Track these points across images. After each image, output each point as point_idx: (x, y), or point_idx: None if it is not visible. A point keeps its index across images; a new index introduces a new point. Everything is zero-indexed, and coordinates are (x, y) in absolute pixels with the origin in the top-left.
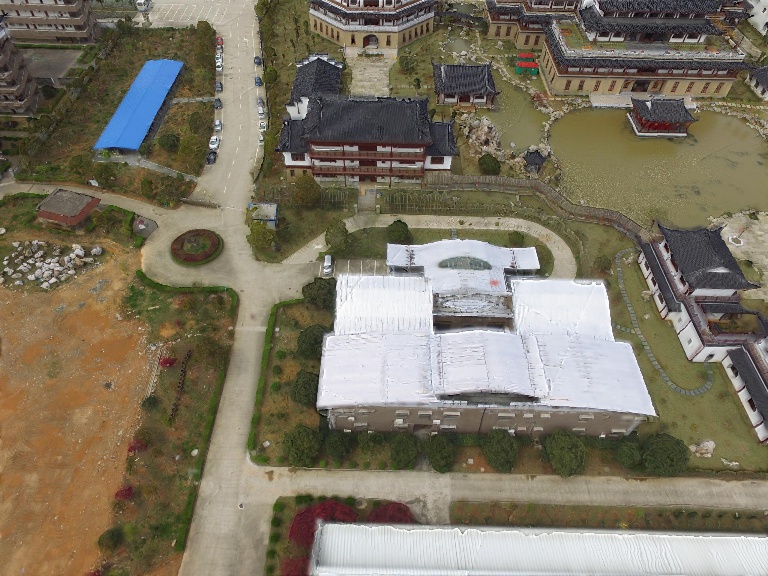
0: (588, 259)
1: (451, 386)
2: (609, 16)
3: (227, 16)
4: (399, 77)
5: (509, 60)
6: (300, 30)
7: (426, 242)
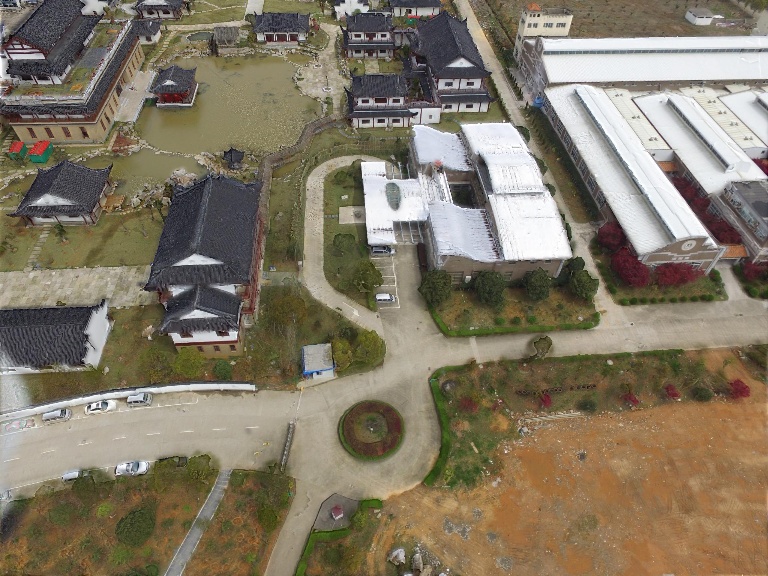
0: (371, 140)
1: (536, 184)
2: (45, 55)
3: None
4: (6, 260)
5: (19, 161)
6: None
7: None
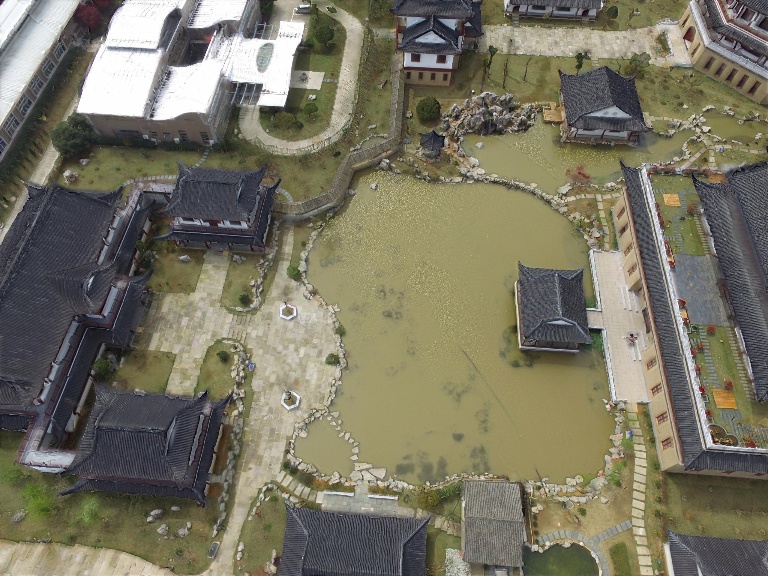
0: None
1: (130, 5)
2: None
3: None
4: None
5: None
6: None
7: (323, 63)
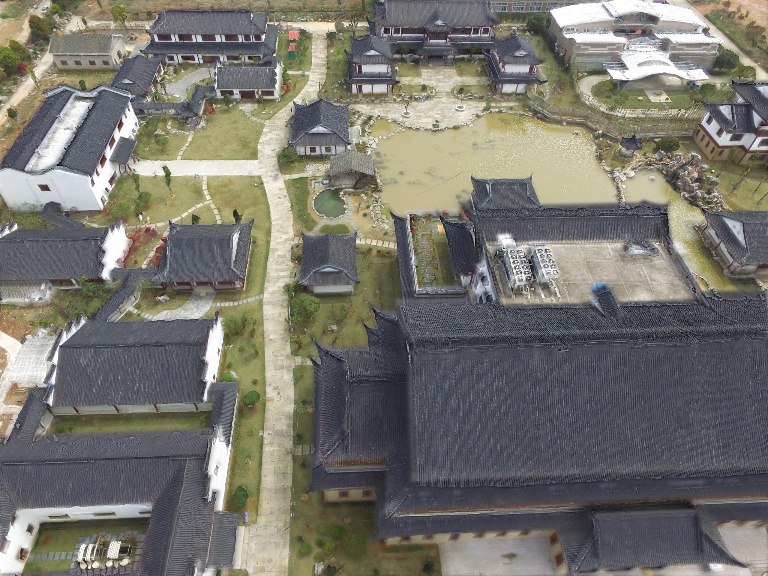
0: None
1: (645, 3)
2: None
3: None
4: None
5: None
6: None
7: (683, 101)
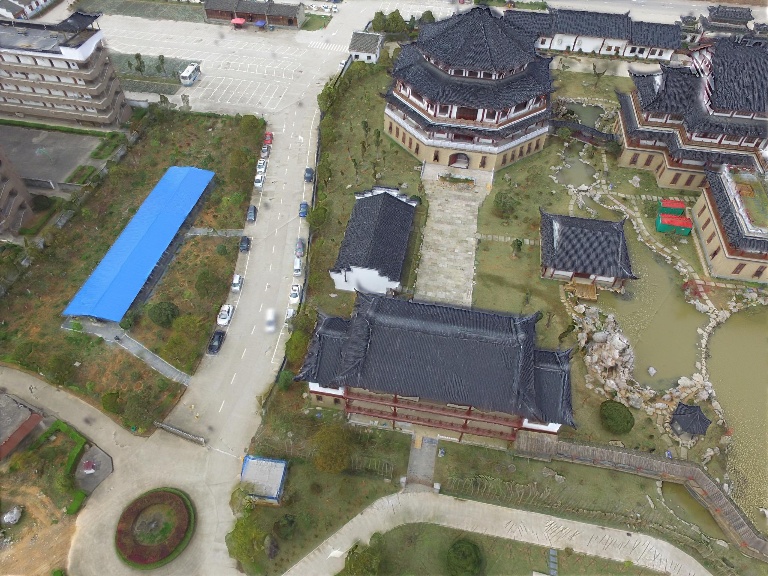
0: None
1: None
2: None
3: (285, 99)
4: (491, 221)
5: (649, 209)
6: (370, 130)
7: (507, 574)
